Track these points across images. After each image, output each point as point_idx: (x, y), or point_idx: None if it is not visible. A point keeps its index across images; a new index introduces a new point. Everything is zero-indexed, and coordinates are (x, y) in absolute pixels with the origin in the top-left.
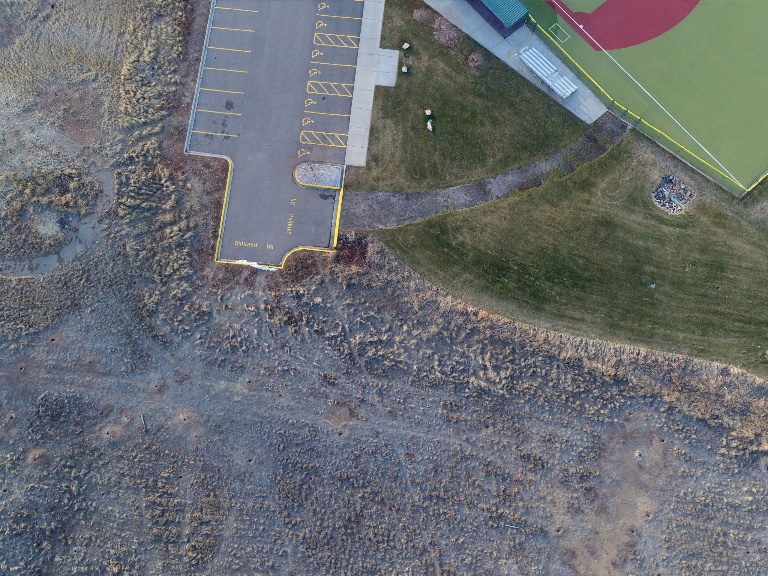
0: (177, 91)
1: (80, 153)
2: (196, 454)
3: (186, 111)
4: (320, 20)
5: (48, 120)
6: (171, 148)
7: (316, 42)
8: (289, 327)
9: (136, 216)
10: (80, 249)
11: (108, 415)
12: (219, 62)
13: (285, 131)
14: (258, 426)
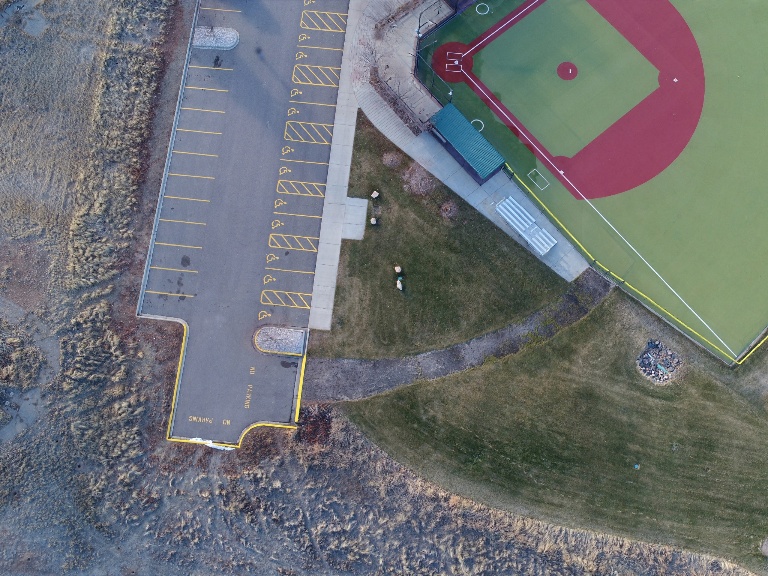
0: (130, 247)
1: (23, 319)
2: None
3: (139, 269)
4: (284, 165)
5: None
6: (122, 311)
7: (279, 190)
8: (245, 515)
9: (82, 390)
10: (21, 429)
11: None
12: (175, 213)
13: (245, 290)
14: None
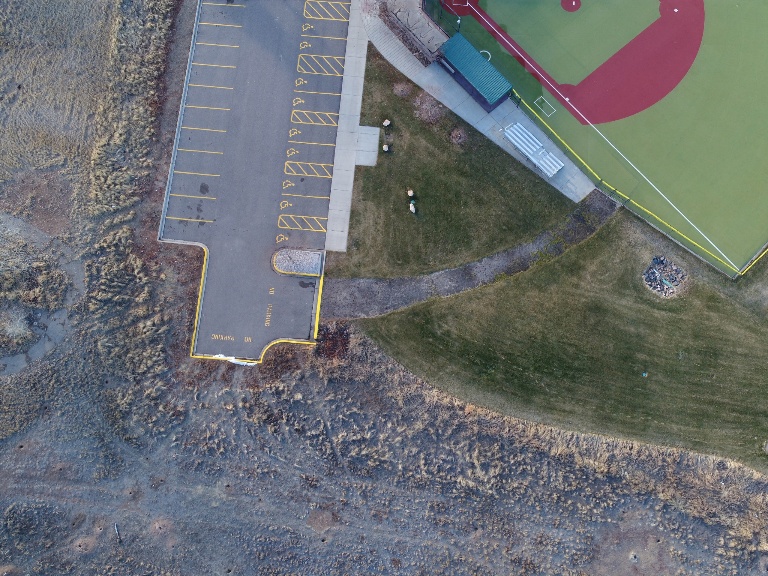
0: (150, 175)
1: (49, 244)
2: (173, 565)
3: (159, 196)
4: (297, 96)
5: (15, 209)
6: (144, 236)
7: (294, 120)
8: (268, 426)
9: (108, 310)
10: (49, 347)
11: (80, 526)
12: (193, 143)
13: (262, 215)
14: (237, 534)
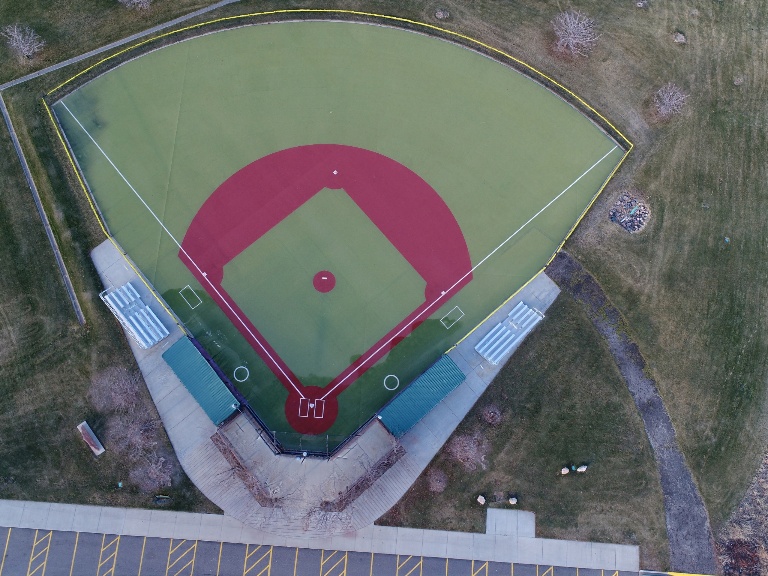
0: None
1: None
2: None
3: None
4: None
5: None
6: None
7: None
8: None
9: None
10: None
11: None
12: None
13: None
14: None
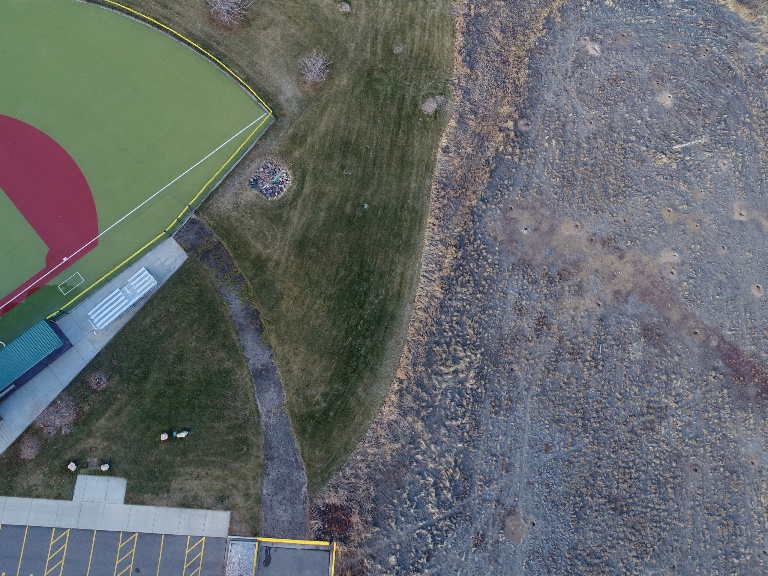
0: None
1: None
2: None
3: None
4: None
5: None
6: None
7: None
8: None
9: None
10: None
11: None
12: None
13: None
14: None
